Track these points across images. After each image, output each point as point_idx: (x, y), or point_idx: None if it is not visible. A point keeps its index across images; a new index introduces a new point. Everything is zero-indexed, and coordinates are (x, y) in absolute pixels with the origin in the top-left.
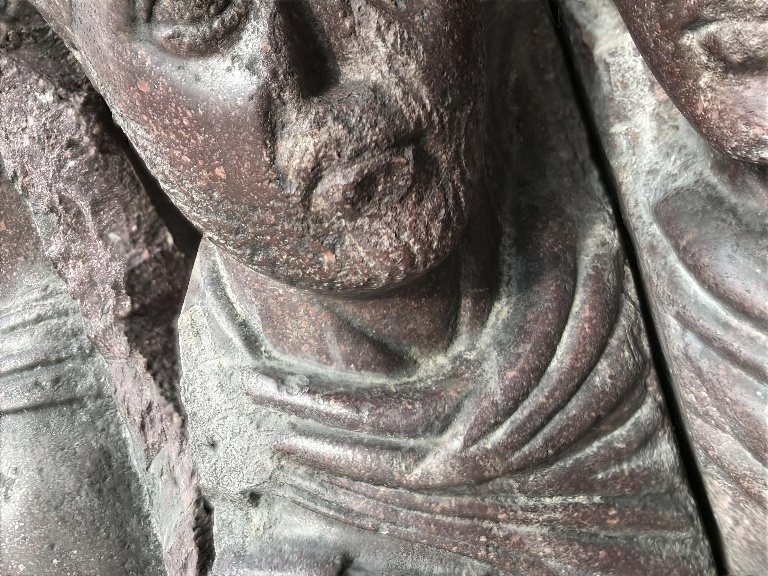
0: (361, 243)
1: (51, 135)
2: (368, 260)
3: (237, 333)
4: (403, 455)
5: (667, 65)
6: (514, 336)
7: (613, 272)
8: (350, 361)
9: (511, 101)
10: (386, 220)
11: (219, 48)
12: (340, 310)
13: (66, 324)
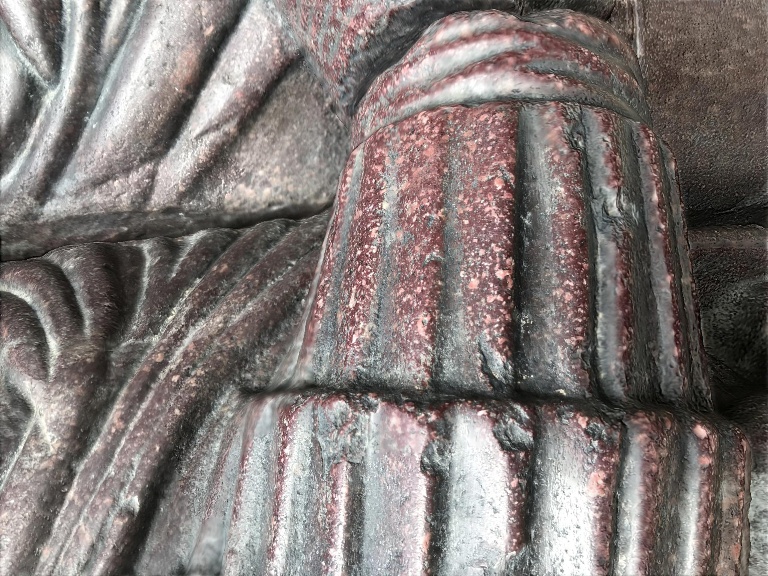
0: None
1: None
2: None
3: None
4: (23, 455)
5: None
6: None
7: None
8: None
9: None
10: None
11: None
12: None
13: None
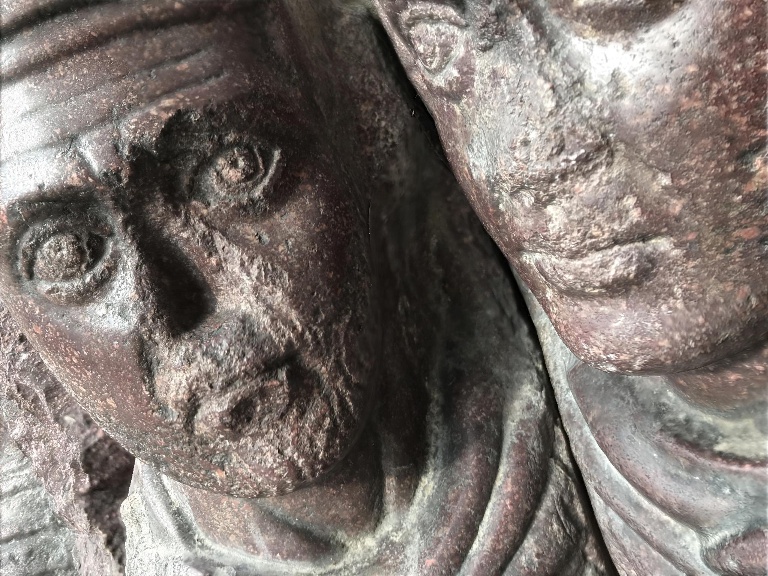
0: (247, 460)
1: (6, 332)
2: (255, 476)
3: (171, 522)
4: None
5: (521, 274)
6: (435, 517)
7: (538, 438)
8: (275, 551)
9: (435, 264)
10: (268, 437)
11: (95, 298)
12: (261, 501)
13: (40, 495)
